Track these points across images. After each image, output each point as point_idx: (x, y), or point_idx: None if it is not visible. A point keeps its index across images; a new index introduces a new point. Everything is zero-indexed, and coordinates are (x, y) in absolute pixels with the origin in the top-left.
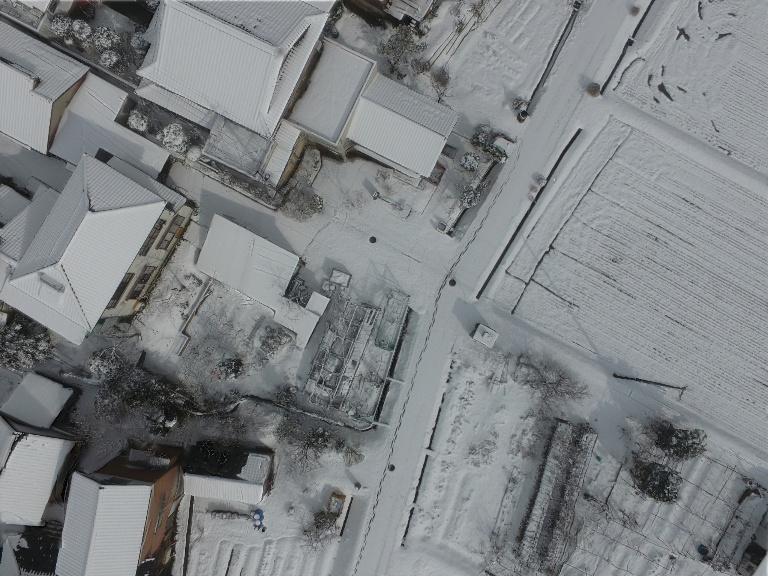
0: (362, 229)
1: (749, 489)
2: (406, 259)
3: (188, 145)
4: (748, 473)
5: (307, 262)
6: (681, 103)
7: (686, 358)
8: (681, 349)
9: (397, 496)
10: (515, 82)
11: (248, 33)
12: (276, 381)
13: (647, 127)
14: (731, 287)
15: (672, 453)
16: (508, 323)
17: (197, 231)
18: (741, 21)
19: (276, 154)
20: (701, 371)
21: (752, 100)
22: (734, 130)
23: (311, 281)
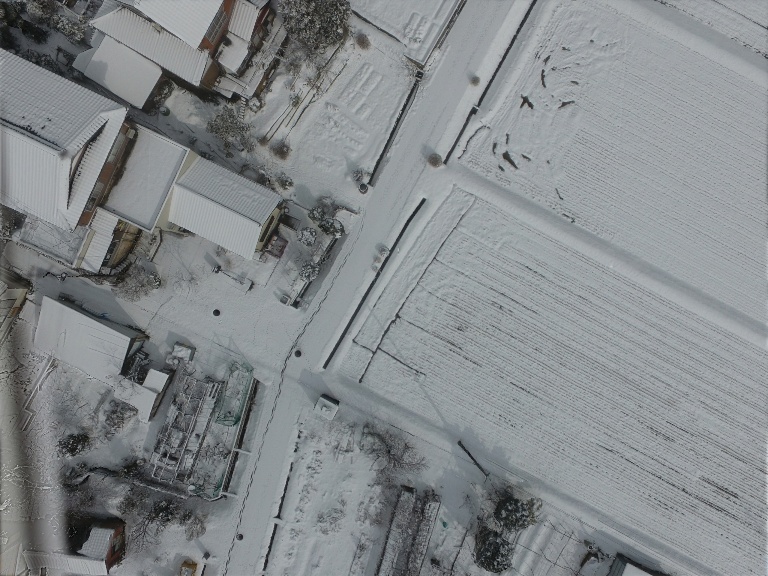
0: (205, 302)
1: (590, 553)
2: (251, 331)
3: (12, 229)
4: (590, 537)
5: (151, 336)
6: (525, 171)
7: (531, 424)
8: (526, 415)
9: (246, 565)
10: (357, 153)
11: (33, 135)
12: (123, 454)
13: (490, 197)
14: (574, 354)
15: (502, 525)
16: (353, 393)
17: (33, 310)
18: (584, 89)
19: (96, 240)
20: (545, 437)
21: (595, 168)
22: (578, 198)
23: (155, 355)
